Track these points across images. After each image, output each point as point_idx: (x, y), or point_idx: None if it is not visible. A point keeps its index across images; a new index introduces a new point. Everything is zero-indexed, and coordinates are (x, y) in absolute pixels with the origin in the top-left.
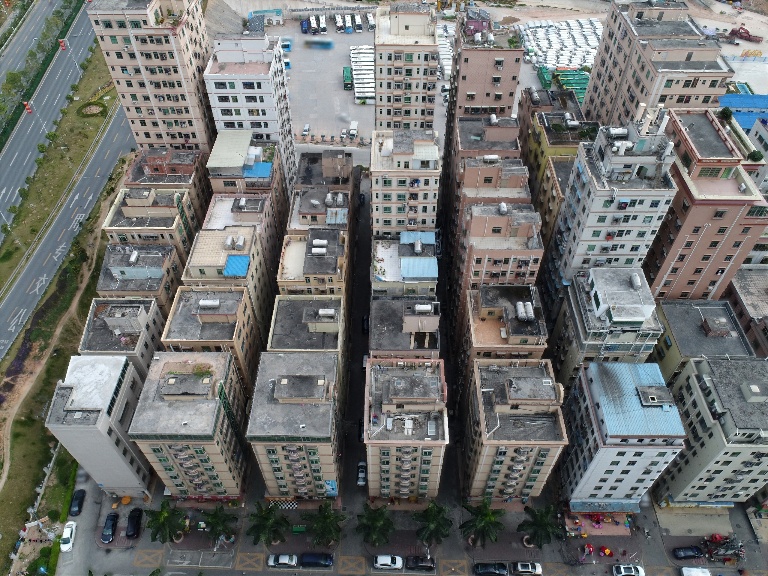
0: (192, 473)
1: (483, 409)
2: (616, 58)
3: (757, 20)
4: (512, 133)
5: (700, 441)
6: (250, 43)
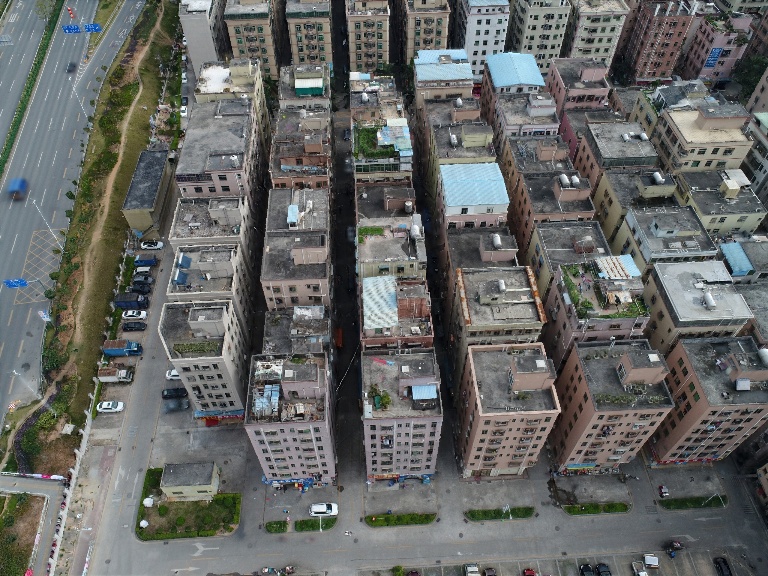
0: (254, 56)
1: (408, 7)
2: None
3: None
4: None
5: (522, 22)
6: None
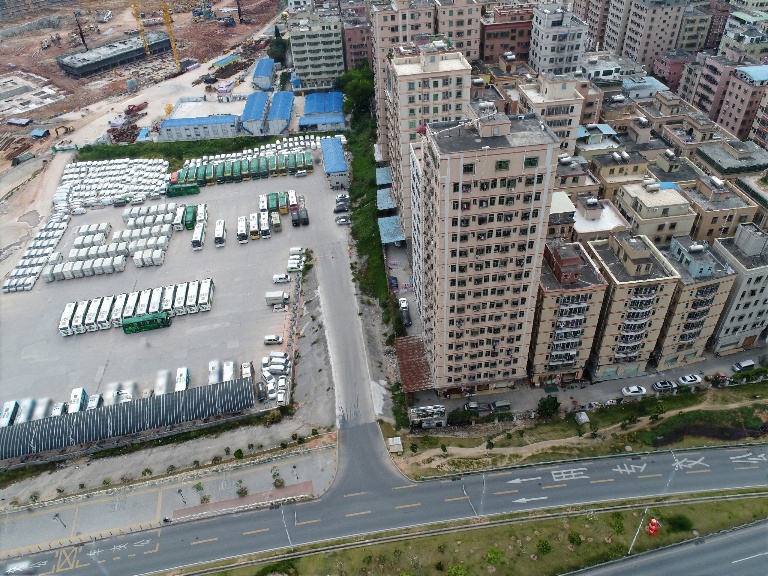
0: None
1: None
2: None
3: (104, 105)
4: None
5: None
6: None
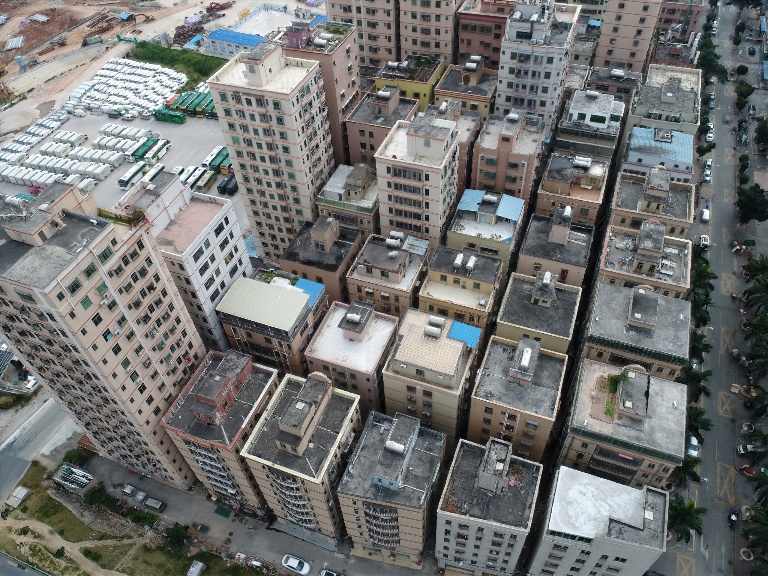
0: None
1: None
2: (371, 7)
3: None
4: (397, 96)
5: None
6: (169, 192)
